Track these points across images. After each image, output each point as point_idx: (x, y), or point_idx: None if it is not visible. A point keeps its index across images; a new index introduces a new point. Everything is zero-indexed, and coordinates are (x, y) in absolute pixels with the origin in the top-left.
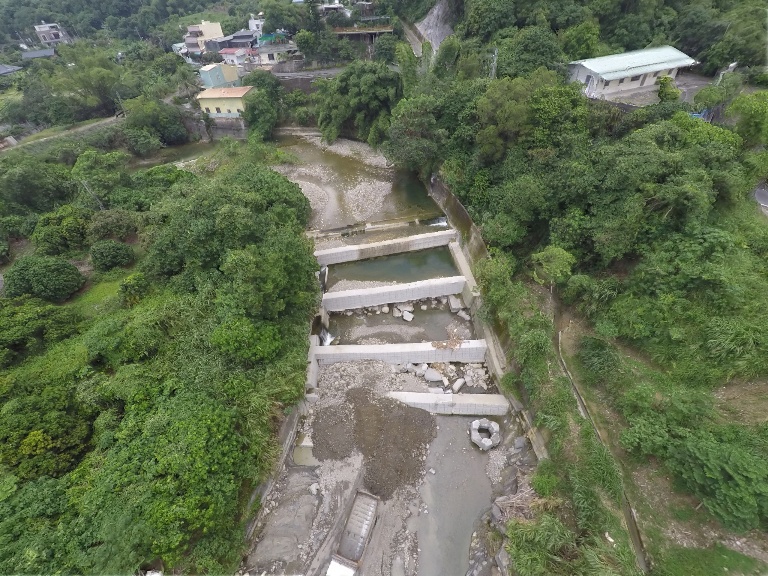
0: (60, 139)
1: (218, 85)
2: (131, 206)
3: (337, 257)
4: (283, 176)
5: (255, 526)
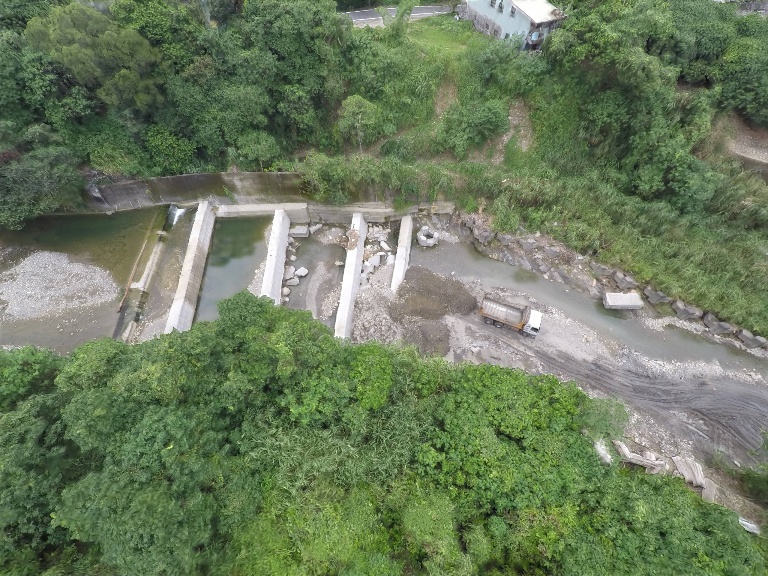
0: None
1: None
2: None
3: None
4: None
5: None
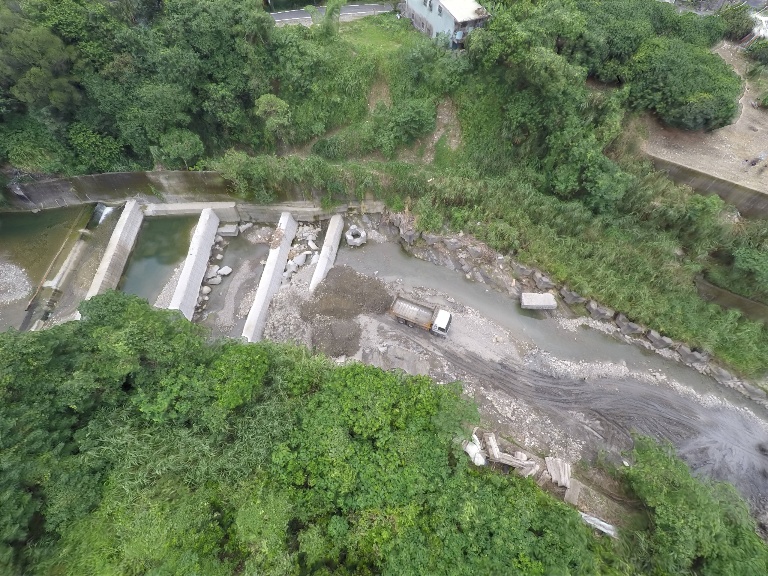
0: None
1: None
2: None
3: None
4: None
5: None
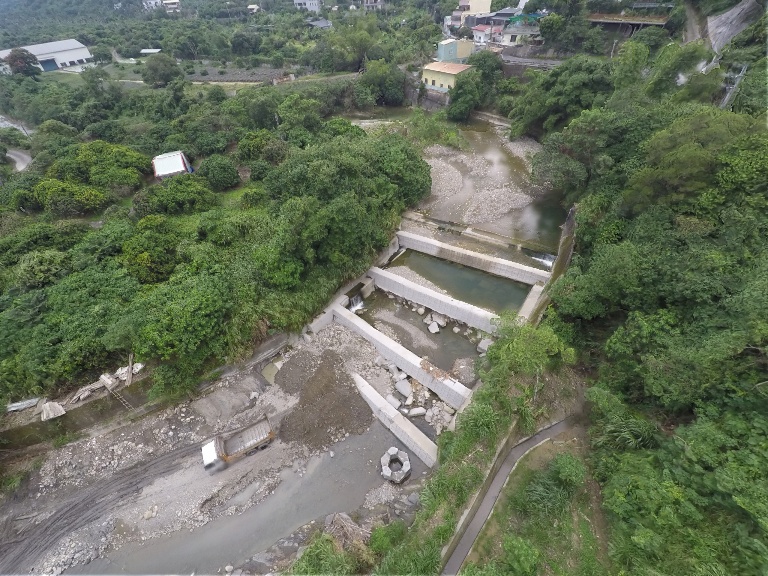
0: (315, 82)
1: (448, 59)
2: (298, 142)
3: (418, 245)
4: (418, 155)
5: (209, 388)
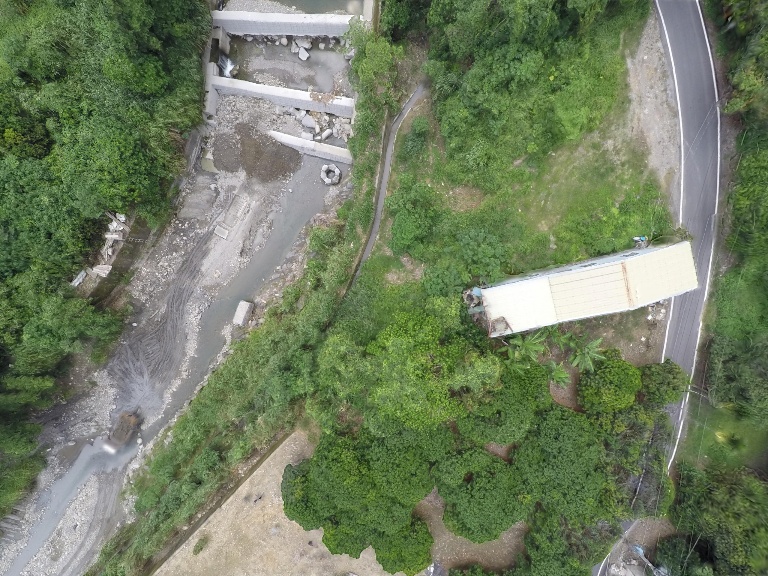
0: None
1: None
2: None
3: None
4: None
5: (179, 200)
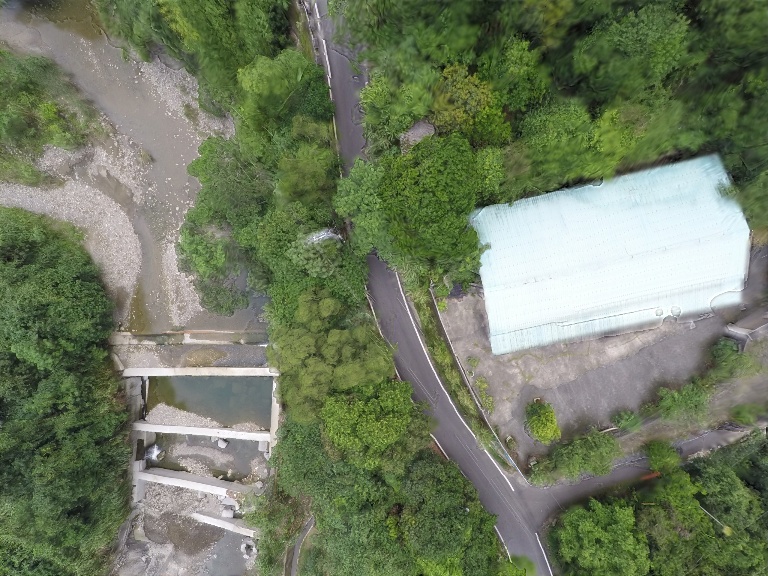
0: None
1: None
2: None
3: None
4: (46, 296)
5: None
